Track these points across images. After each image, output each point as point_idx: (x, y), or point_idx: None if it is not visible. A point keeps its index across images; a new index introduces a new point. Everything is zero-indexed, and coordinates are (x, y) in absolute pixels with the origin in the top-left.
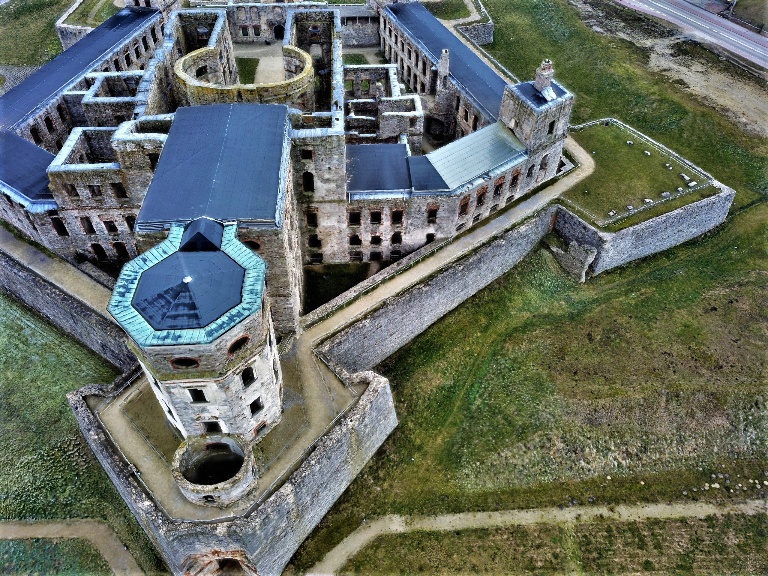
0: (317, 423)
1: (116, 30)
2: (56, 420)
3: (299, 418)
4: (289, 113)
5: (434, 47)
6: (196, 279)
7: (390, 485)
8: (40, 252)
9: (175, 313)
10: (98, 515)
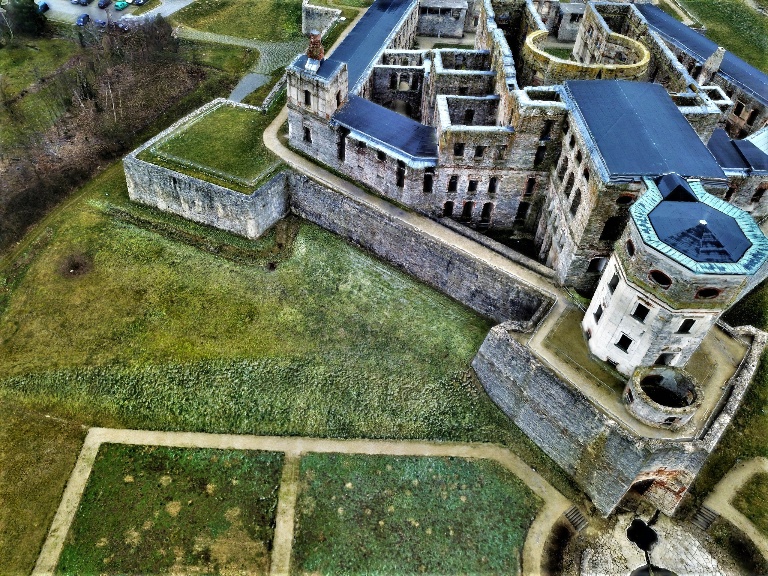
0: (720, 366)
1: (389, 12)
2: (445, 355)
3: (703, 361)
4: None
5: (692, 45)
6: (710, 222)
7: (750, 431)
8: (396, 206)
9: (707, 249)
10: (497, 441)
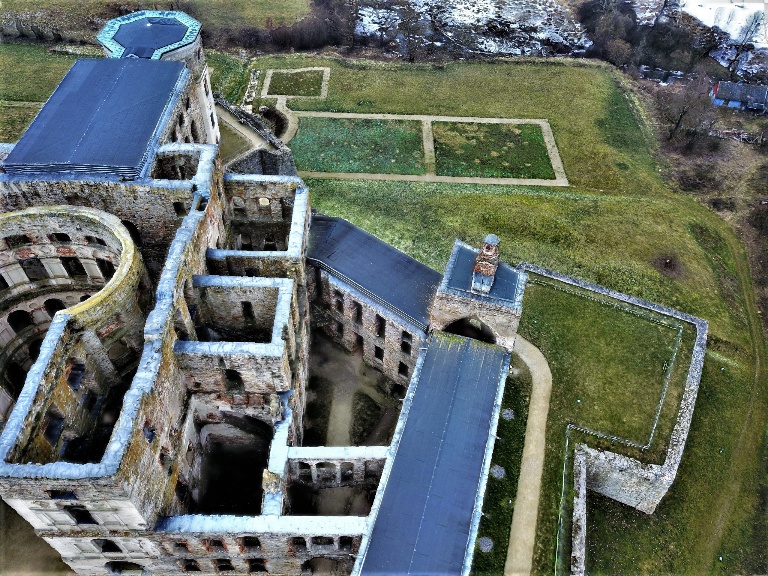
0: None
1: None
2: (321, 195)
3: None
4: (5, 174)
5: None
6: None
7: None
8: None
9: None
10: None
